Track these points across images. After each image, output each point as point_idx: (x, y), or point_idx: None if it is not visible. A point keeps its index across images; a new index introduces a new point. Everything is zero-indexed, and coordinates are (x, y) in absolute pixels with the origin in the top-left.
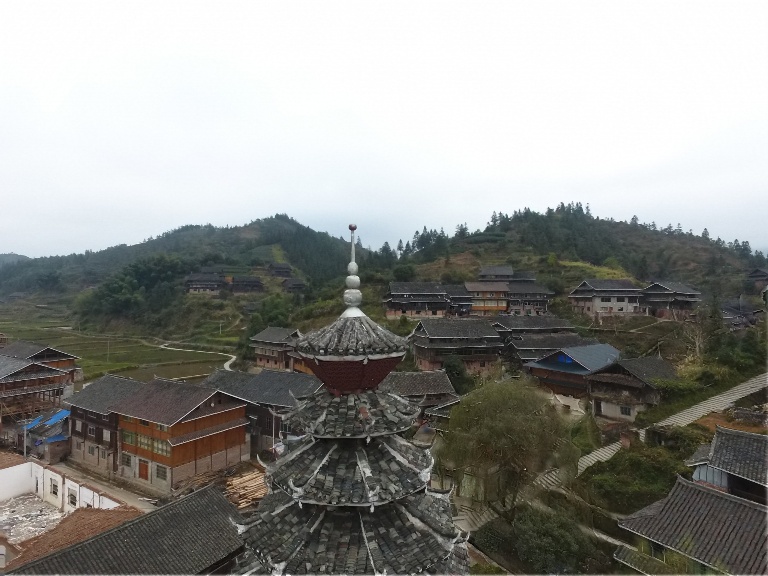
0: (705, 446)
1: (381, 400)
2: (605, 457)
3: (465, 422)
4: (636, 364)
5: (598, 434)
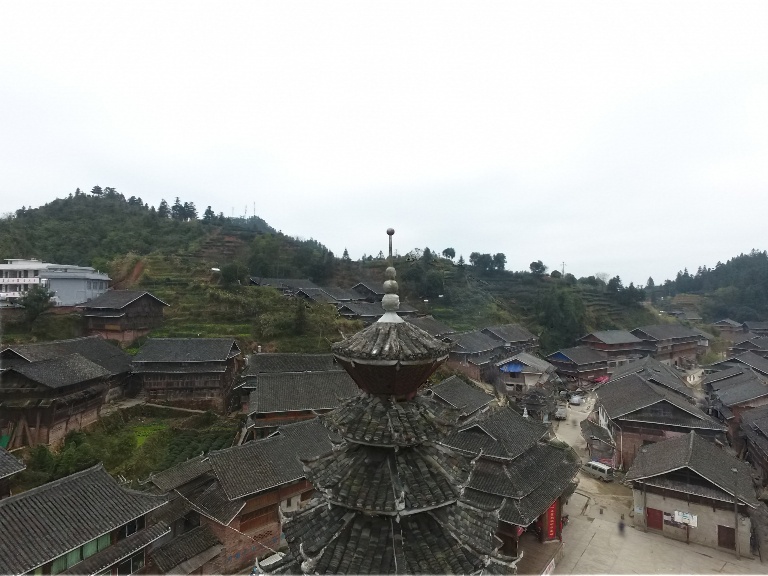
0: None
1: None
2: None
3: None
4: None
5: None
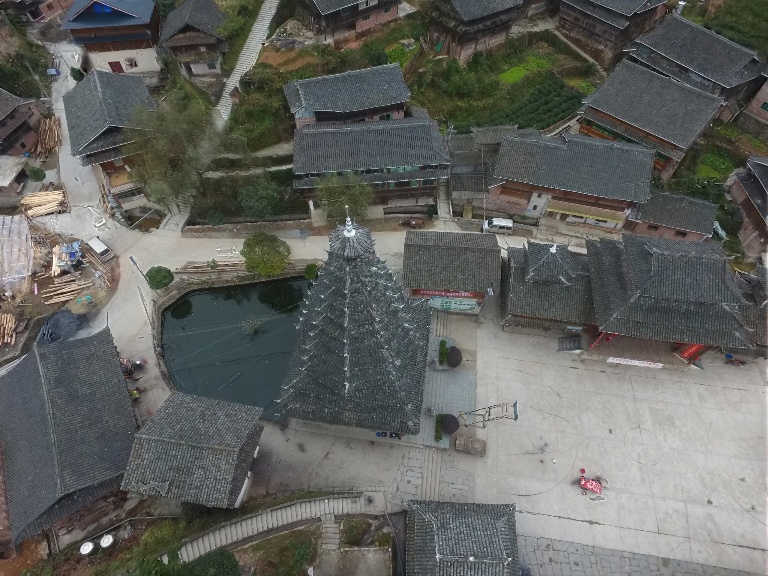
0: (286, 88)
1: None
2: (225, 115)
3: (167, 162)
4: (196, 16)
5: (208, 97)
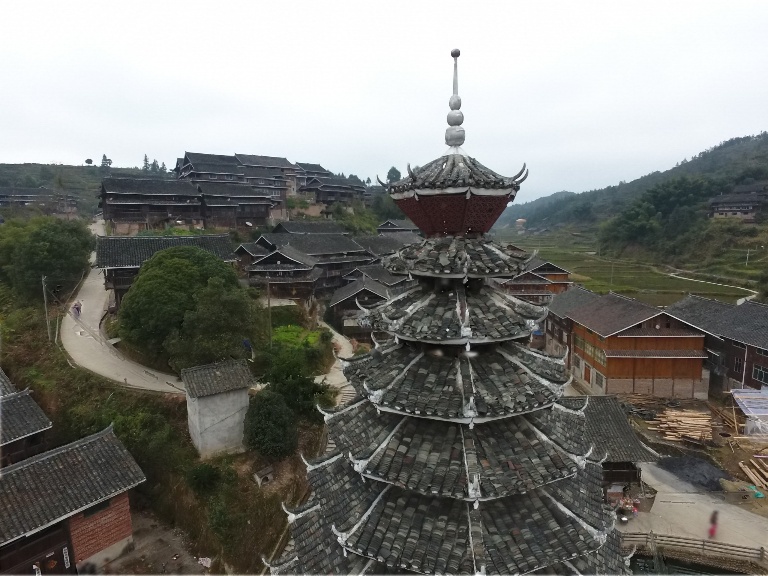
0: None
1: (453, 245)
2: None
3: None
4: None
5: None
